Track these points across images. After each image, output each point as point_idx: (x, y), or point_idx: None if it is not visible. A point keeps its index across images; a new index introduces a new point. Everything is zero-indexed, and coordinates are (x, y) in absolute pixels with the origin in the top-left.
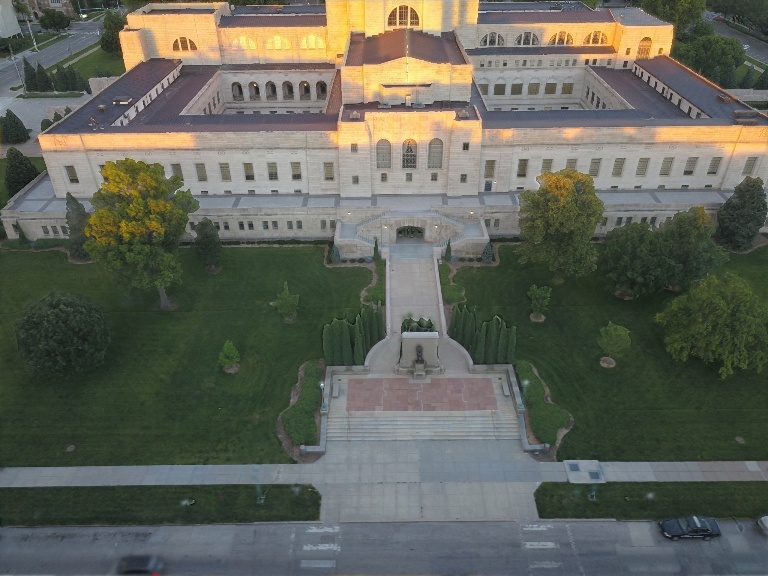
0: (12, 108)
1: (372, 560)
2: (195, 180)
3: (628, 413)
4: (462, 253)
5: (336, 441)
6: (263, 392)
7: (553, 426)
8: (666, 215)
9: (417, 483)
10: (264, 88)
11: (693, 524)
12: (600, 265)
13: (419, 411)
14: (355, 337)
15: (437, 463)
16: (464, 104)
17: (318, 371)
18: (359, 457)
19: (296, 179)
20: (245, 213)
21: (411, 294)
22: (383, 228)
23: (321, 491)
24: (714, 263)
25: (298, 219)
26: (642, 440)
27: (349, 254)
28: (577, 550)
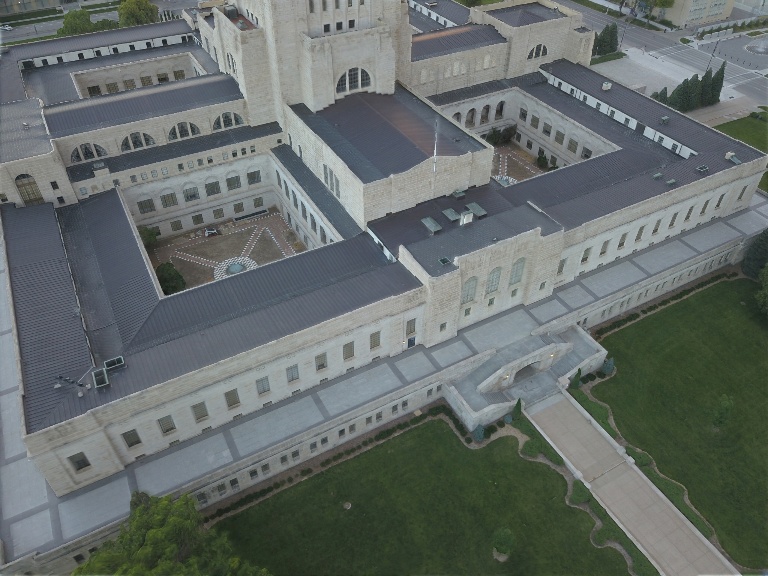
0: (665, 79)
1: None
2: None
3: None
4: None
5: None
6: None
7: None
8: None
9: None
10: None
11: None
12: None
13: None
14: None
15: None
16: None
17: None
18: None
19: None
20: None
21: None
22: None
23: None
24: None
25: None
26: None
27: None
28: None
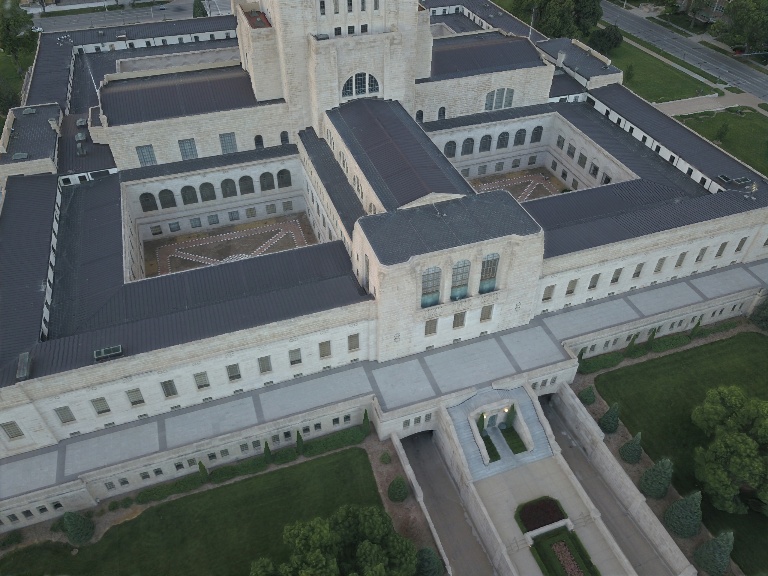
0: None
1: None
2: None
3: None
4: None
5: None
6: None
7: None
8: None
9: None
10: None
11: None
12: None
13: None
14: None
15: None
16: None
17: None
18: None
19: None
20: None
21: None
22: None
23: None
24: None
25: None
26: None
27: None
28: None
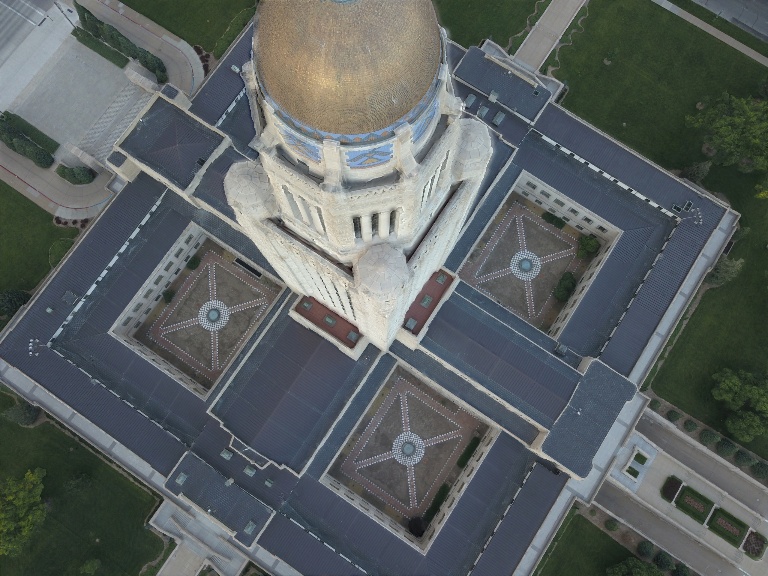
0: (60, 66)
1: None
2: None
3: None
4: None
5: None
6: None
7: None
8: None
9: None
10: None
11: None
12: None
13: None
14: None
15: None
16: None
17: None
18: None
19: None
20: None
21: None
22: None
23: None
24: None
25: None
26: None
27: None
28: None
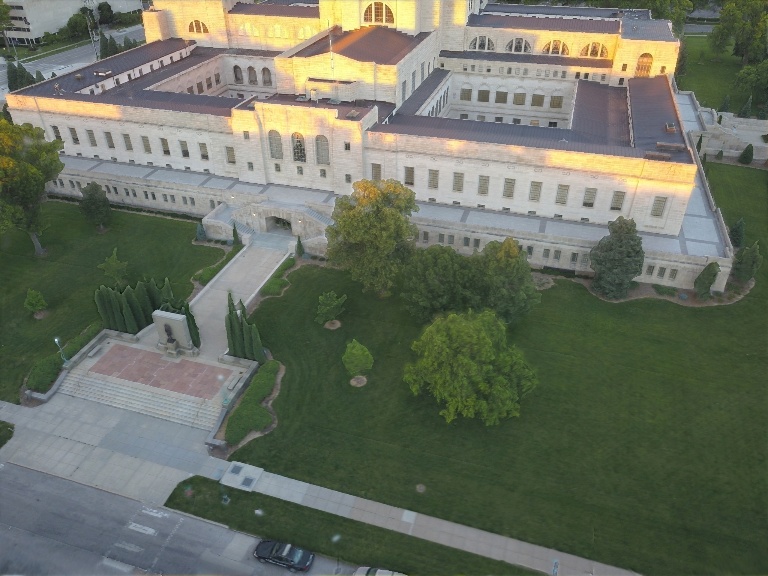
0: None
1: (1, 499)
2: (123, 149)
3: (332, 433)
4: (316, 251)
5: (64, 394)
6: (45, 340)
7: (244, 427)
8: (543, 246)
9: (93, 446)
10: (261, 73)
11: (281, 551)
12: (402, 283)
13: (145, 385)
14: (123, 306)
15: (125, 434)
16: (390, 105)
17: (95, 331)
18: (69, 412)
19: (205, 159)
20: (148, 184)
21: (238, 281)
22: (252, 215)
23: (16, 432)
24: (517, 302)
25: (191, 196)
26: (322, 462)
27: (216, 235)
28: (168, 543)
